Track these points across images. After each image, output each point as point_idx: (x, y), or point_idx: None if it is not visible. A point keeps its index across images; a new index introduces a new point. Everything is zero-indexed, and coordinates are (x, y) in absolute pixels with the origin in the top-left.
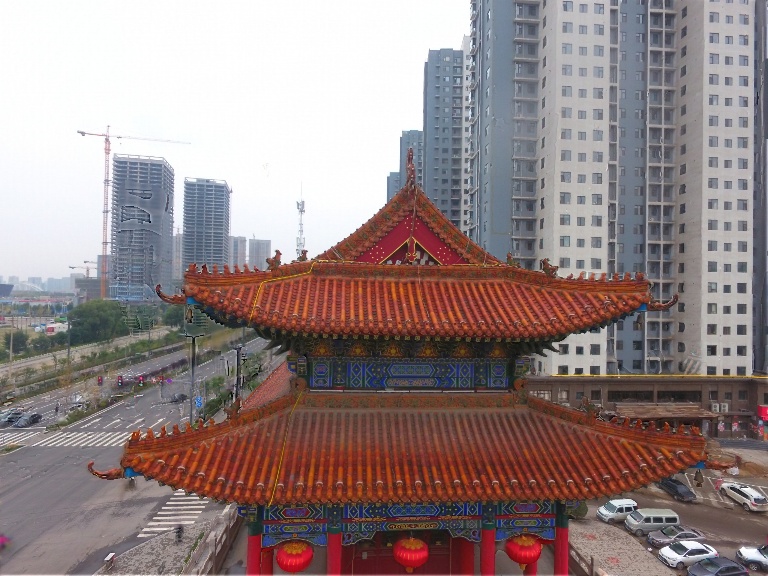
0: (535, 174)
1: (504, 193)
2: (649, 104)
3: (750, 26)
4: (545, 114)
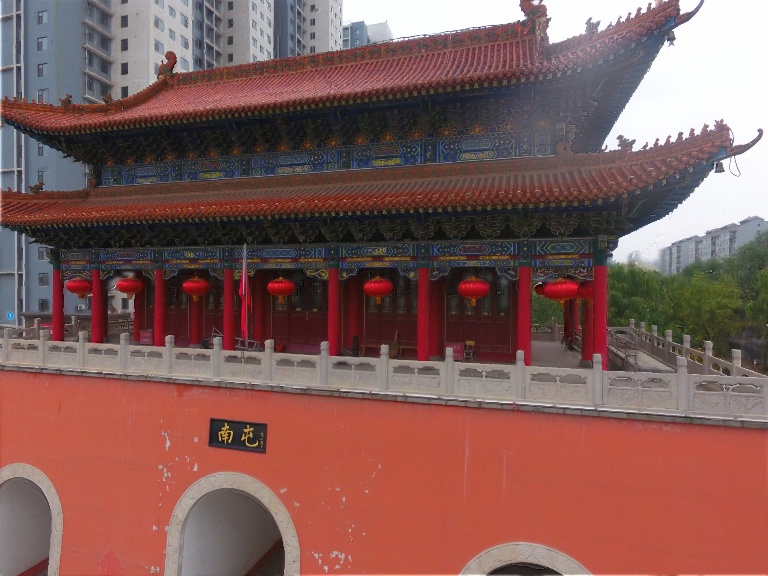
0: (109, 78)
1: (75, 86)
2: (206, 56)
3: (272, 30)
4: (128, 12)
